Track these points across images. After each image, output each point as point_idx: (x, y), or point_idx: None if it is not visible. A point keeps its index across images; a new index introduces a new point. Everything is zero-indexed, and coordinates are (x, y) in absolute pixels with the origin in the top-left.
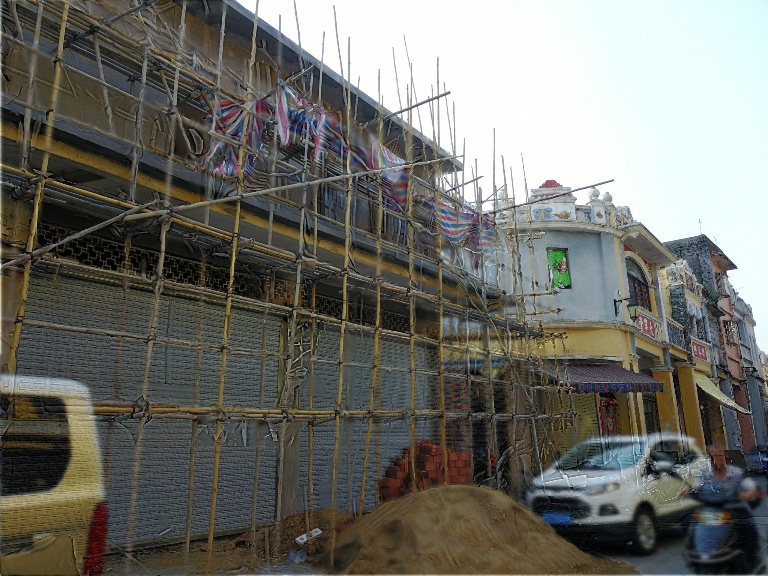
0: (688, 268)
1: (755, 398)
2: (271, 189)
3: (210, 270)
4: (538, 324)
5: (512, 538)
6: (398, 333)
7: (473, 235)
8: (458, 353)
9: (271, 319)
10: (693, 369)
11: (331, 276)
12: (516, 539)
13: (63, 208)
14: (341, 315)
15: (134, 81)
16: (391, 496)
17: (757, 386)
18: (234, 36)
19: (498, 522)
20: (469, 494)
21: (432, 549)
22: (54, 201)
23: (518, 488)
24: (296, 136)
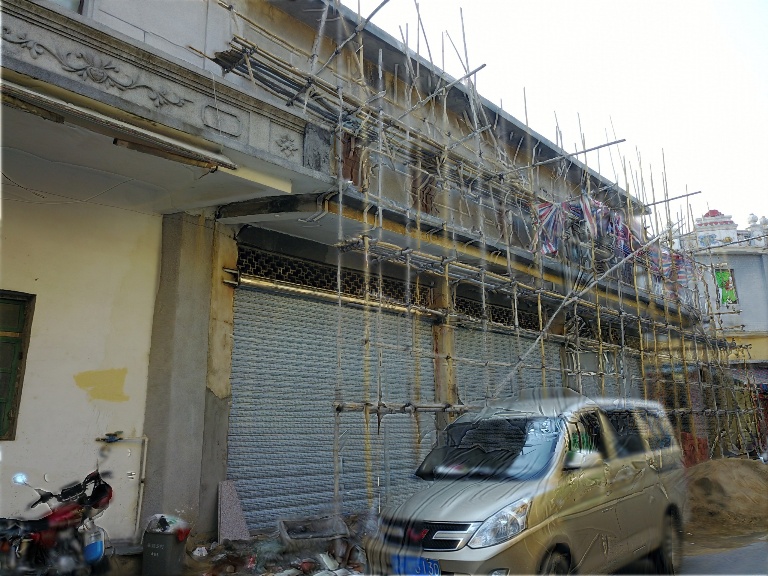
0: None
1: None
2: (607, 272)
3: (524, 315)
4: None
5: None
6: (664, 356)
7: (674, 271)
8: (693, 367)
9: (555, 345)
10: None
11: (633, 322)
12: None
13: (466, 286)
14: (640, 347)
15: (501, 203)
16: (666, 467)
17: None
18: (524, 150)
19: None
20: (742, 463)
21: (736, 494)
22: (536, 299)
23: None
24: (603, 230)
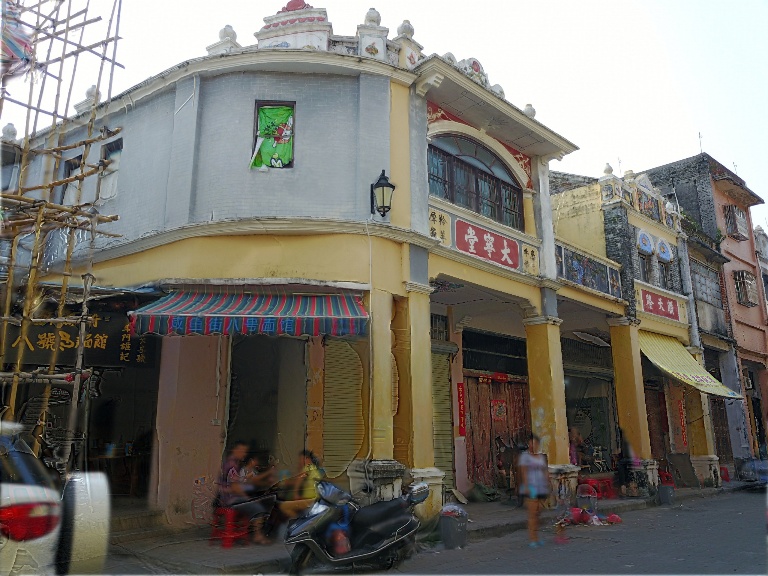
0: (650, 186)
1: None
2: None
3: None
4: (218, 227)
5: None
6: None
7: None
8: None
9: None
10: (635, 329)
11: None
12: None
13: None
14: None
15: None
16: None
17: None
18: None
19: None
20: None
21: None
22: None
23: (82, 521)
24: None
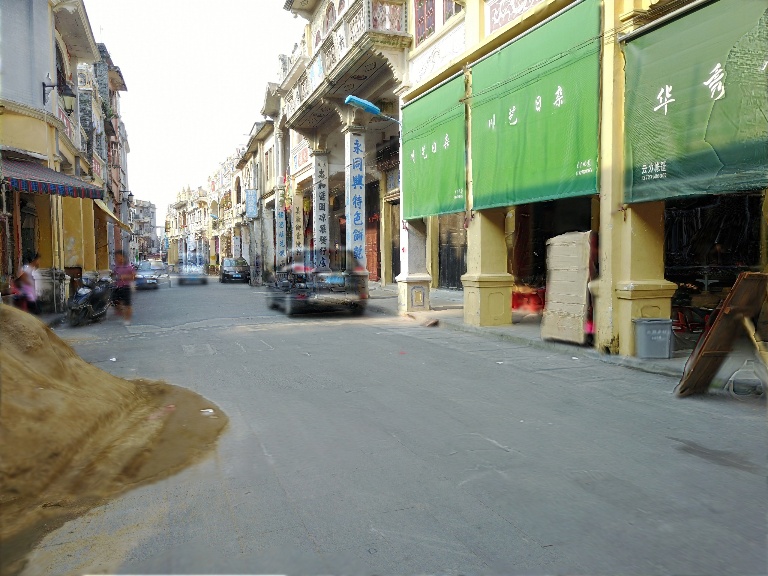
0: None
1: (124, 221)
2: None
3: None
4: None
5: (57, 369)
6: None
7: None
8: None
9: None
10: None
11: None
12: (62, 370)
13: None
14: None
15: None
16: None
17: (127, 210)
18: None
19: (33, 350)
20: None
21: None
22: None
23: None
24: None
